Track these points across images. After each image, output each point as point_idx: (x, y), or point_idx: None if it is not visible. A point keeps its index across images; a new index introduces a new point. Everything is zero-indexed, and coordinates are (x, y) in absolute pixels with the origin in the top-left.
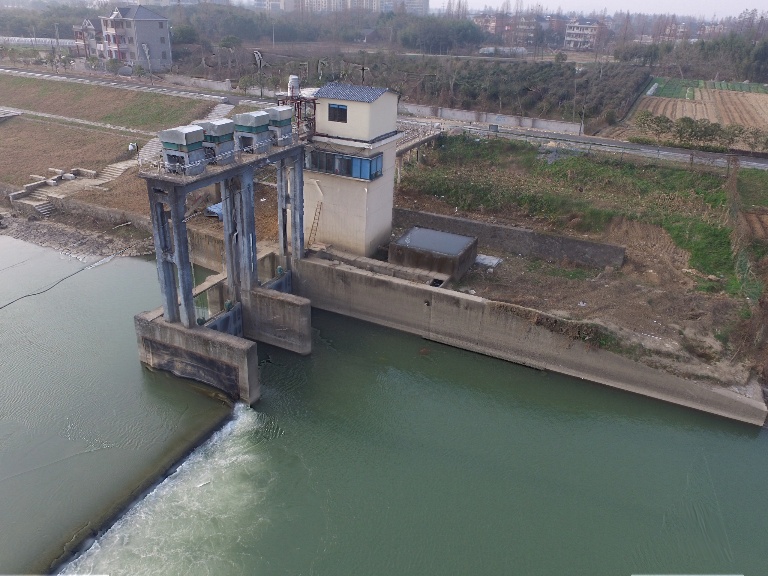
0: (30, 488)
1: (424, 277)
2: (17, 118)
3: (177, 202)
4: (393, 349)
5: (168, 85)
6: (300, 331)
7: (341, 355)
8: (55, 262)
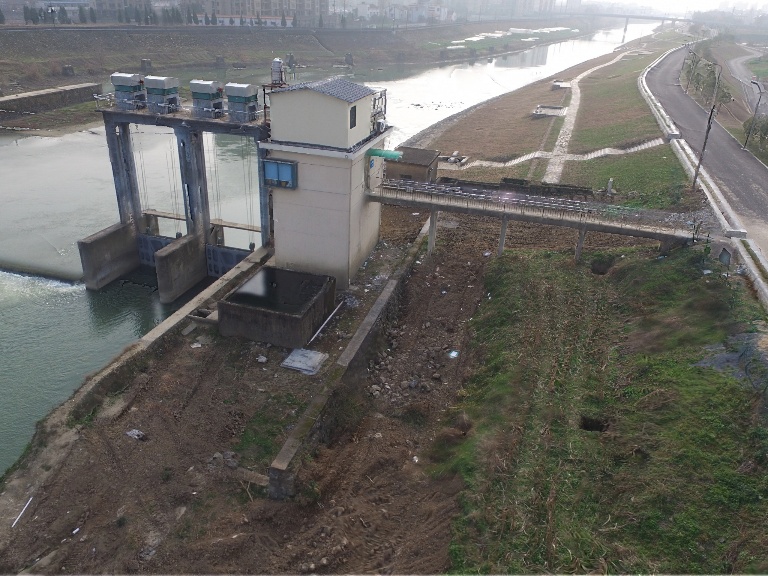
0: (31, 243)
1: None
2: (551, 117)
3: (107, 124)
4: None
5: (725, 118)
6: None
7: None
8: None
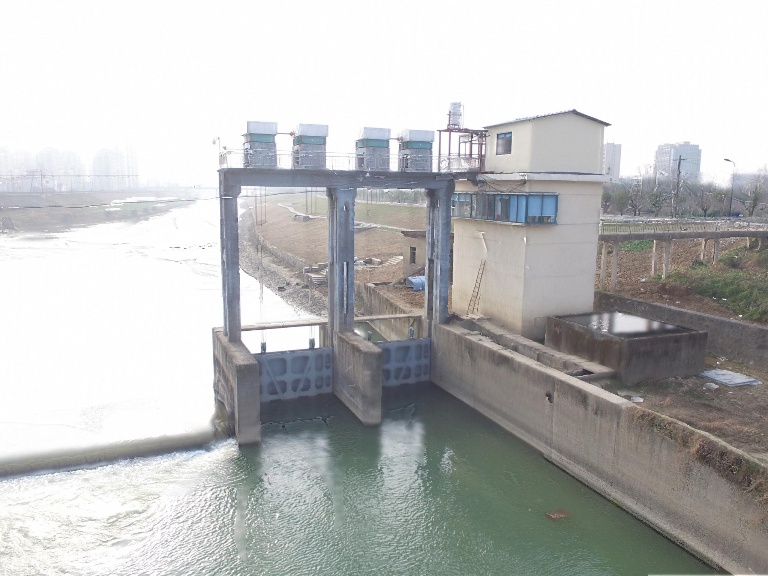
0: (3, 433)
1: (571, 365)
2: (373, 229)
3: (228, 191)
4: (483, 455)
5: None
6: (363, 389)
7: (410, 440)
8: (283, 315)
